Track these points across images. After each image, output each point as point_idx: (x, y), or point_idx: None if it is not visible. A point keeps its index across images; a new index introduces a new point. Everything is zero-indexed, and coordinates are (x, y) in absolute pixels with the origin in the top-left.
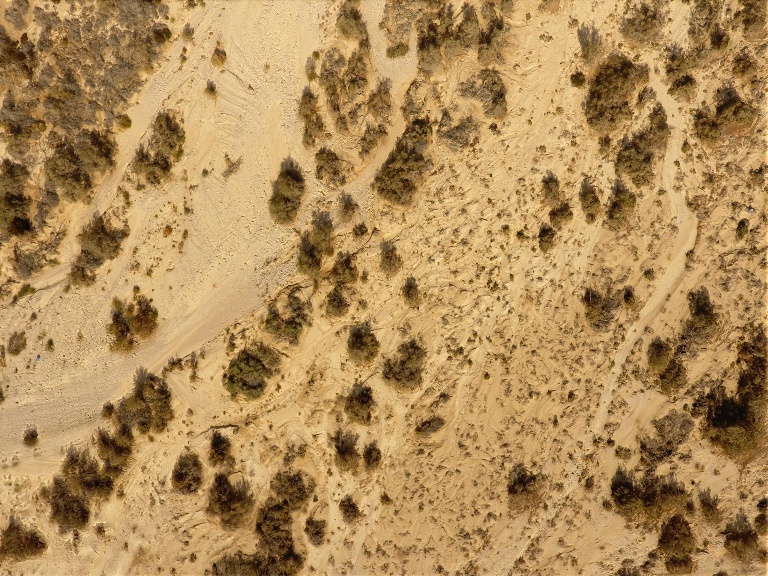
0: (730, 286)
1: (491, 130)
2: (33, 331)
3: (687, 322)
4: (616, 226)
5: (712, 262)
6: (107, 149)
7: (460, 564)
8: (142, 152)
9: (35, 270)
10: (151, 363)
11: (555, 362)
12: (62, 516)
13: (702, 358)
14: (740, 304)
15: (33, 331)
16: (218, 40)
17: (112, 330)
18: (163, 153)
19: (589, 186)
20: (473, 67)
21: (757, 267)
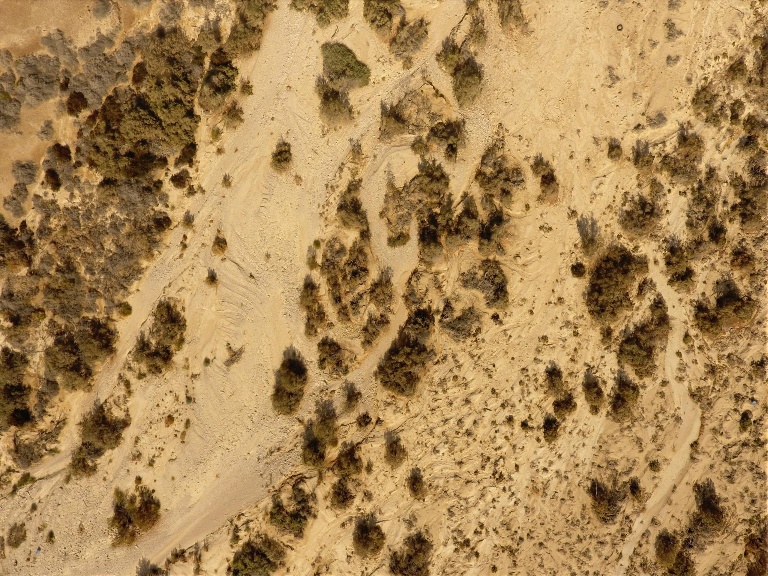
0: (735, 478)
1: (493, 320)
2: (33, 522)
3: (693, 514)
4: (620, 418)
5: (717, 453)
6: (108, 339)
7: None
8: (143, 341)
9: (35, 460)
10: (154, 554)
11: (562, 554)
12: None
13: (710, 551)
14: (746, 496)
15: (33, 522)
16: (218, 228)
17: (114, 525)
18: (164, 344)
19: (592, 377)
20: (474, 257)
21: (761, 459)
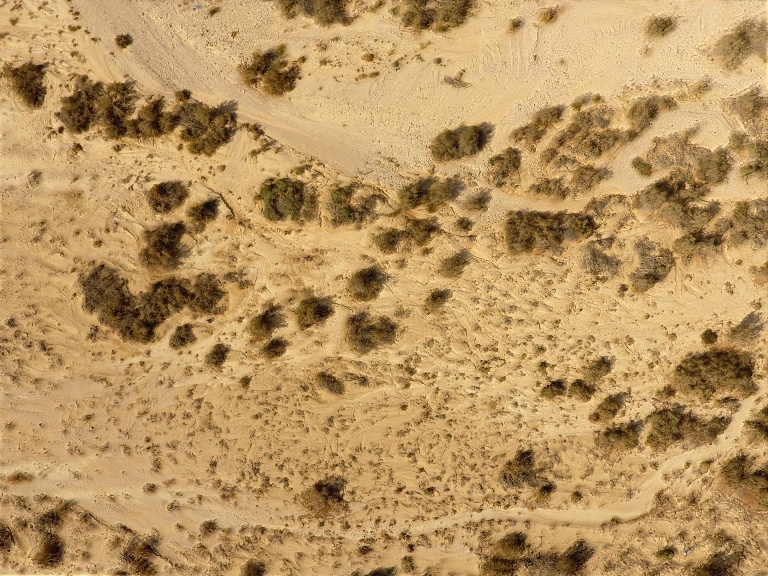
0: (607, 573)
1: (621, 287)
2: None
3: (554, 554)
4: (601, 444)
5: (619, 546)
6: None
7: (228, 478)
8: None
9: None
10: (245, 110)
11: (452, 459)
12: (69, 109)
13: None
14: None
15: None
16: (560, 5)
17: (255, 59)
18: (434, 14)
19: (622, 400)
20: (667, 240)
21: None
